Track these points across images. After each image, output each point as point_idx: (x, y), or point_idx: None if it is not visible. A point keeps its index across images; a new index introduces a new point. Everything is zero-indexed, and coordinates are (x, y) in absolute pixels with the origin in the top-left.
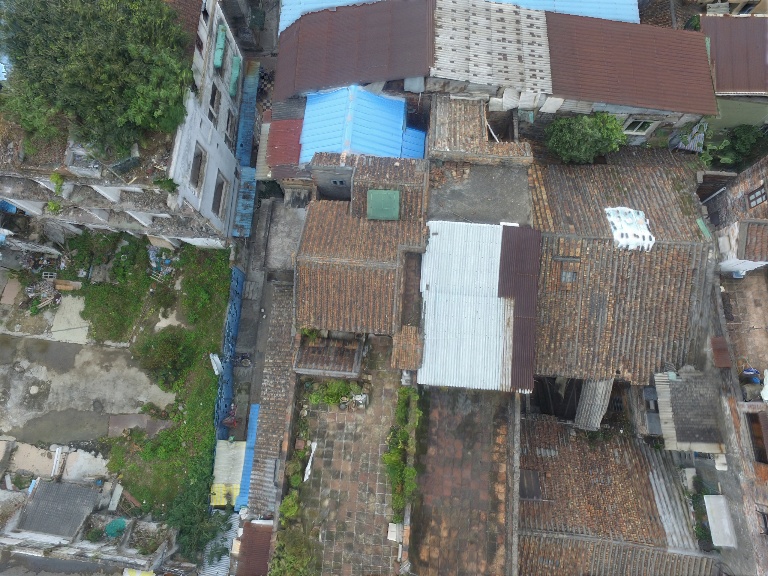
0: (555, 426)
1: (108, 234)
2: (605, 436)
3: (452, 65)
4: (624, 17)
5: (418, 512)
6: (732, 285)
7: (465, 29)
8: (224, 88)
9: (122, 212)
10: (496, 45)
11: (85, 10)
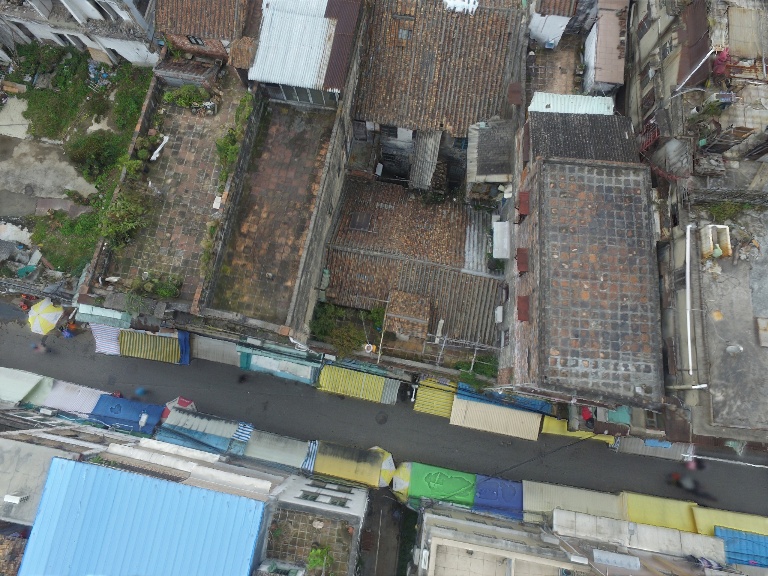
0: (399, 191)
1: (54, 46)
2: (438, 199)
3: None
4: None
5: (245, 199)
6: (545, 56)
7: None
8: None
9: (62, 12)
10: None
11: None
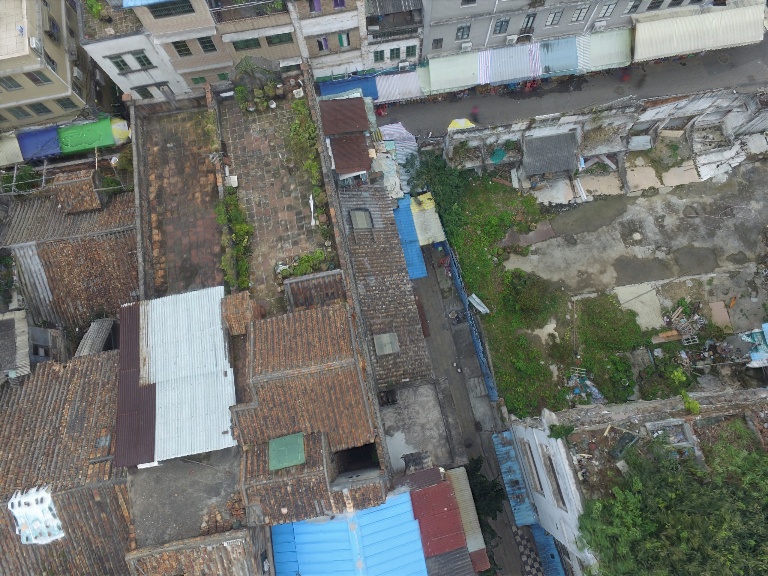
0: None
1: None
2: (90, 320)
3: None
4: None
5: None
6: None
7: None
8: None
9: None
10: None
11: None
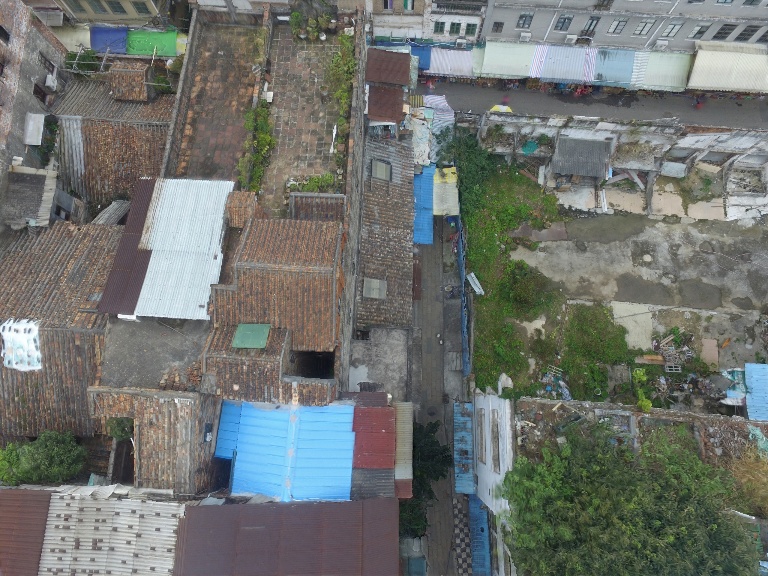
0: None
1: None
2: None
3: (158, 524)
4: None
5: None
6: None
7: None
8: None
9: None
10: (101, 564)
11: None
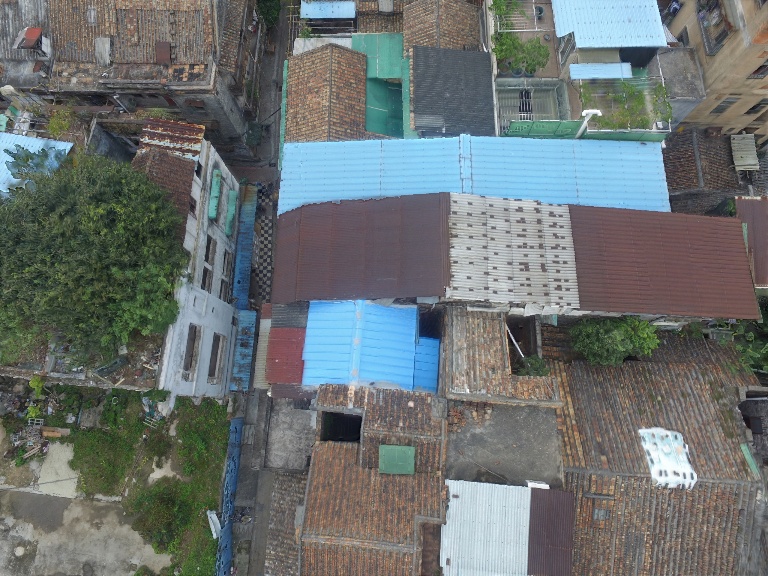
0: None
1: None
2: None
3: (469, 282)
4: (652, 196)
5: None
6: None
7: (482, 236)
8: (220, 232)
9: None
10: (517, 253)
11: (64, 228)
